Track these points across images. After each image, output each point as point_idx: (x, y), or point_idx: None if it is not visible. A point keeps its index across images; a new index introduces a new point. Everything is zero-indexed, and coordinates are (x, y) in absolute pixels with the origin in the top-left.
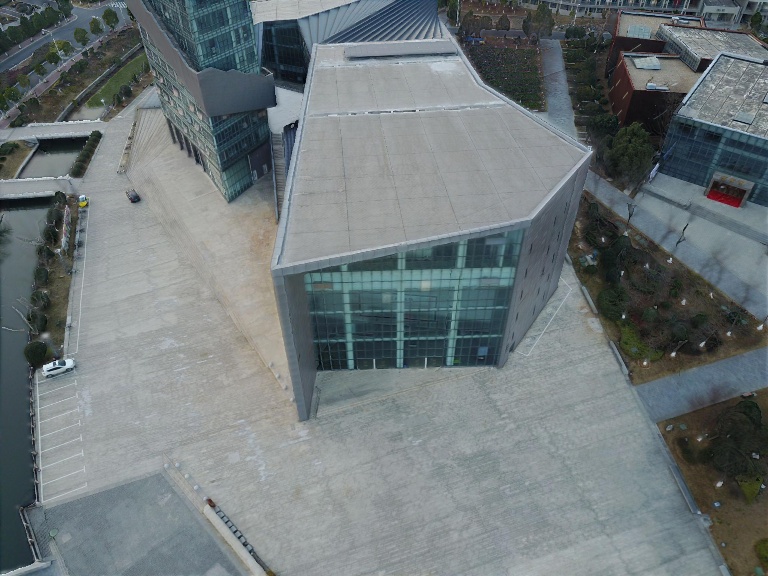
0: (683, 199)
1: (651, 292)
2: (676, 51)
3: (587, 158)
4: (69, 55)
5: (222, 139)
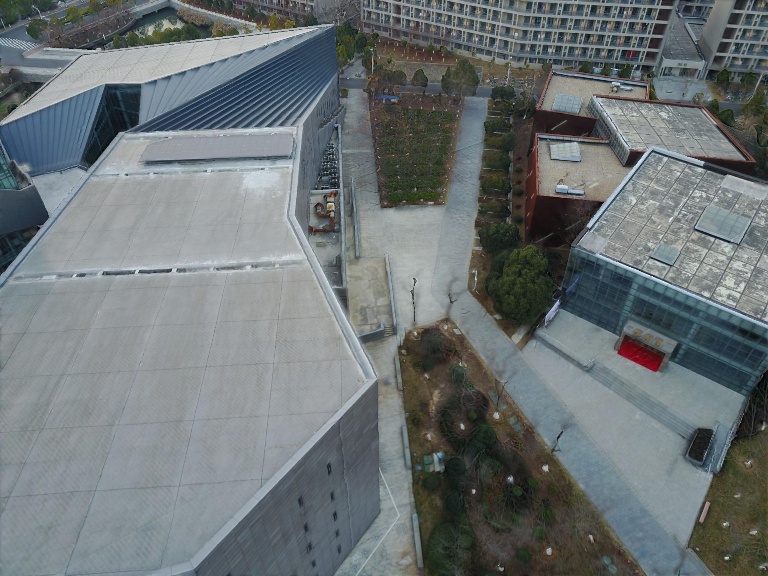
0: (583, 358)
1: (507, 529)
2: (606, 134)
3: (360, 396)
4: None
5: None
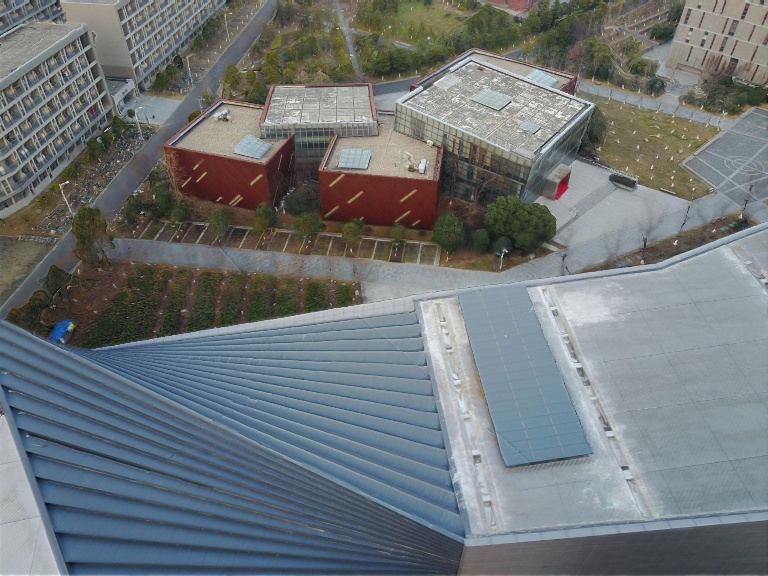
0: None
1: None
2: (323, 134)
3: None
4: None
5: None
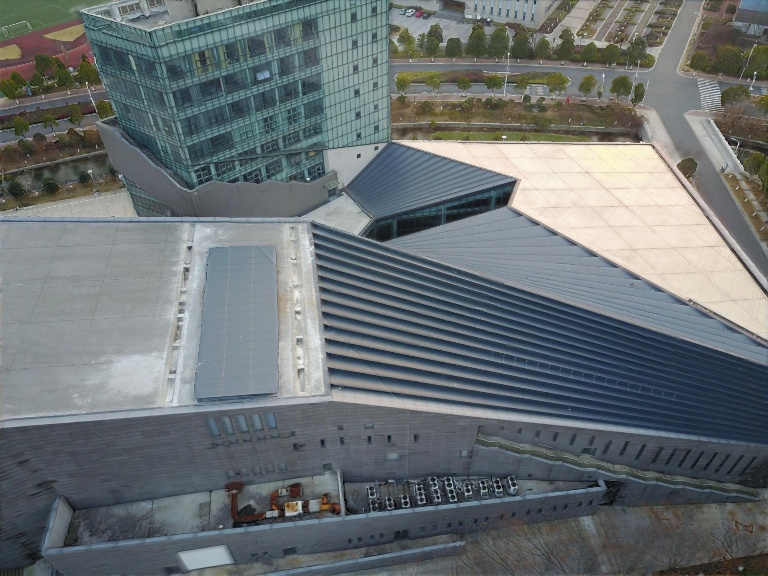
0: None
1: None
2: None
3: None
4: (517, 90)
5: (141, 202)
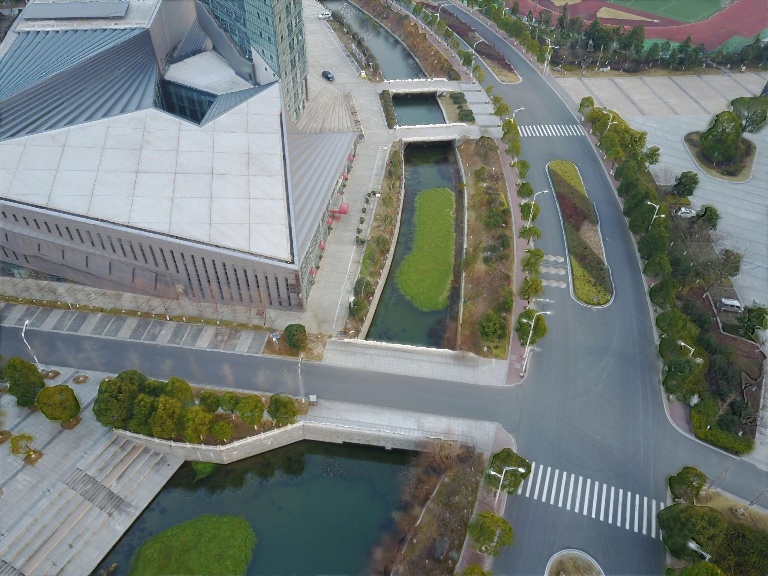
0: None
1: None
2: None
3: None
4: None
5: None
